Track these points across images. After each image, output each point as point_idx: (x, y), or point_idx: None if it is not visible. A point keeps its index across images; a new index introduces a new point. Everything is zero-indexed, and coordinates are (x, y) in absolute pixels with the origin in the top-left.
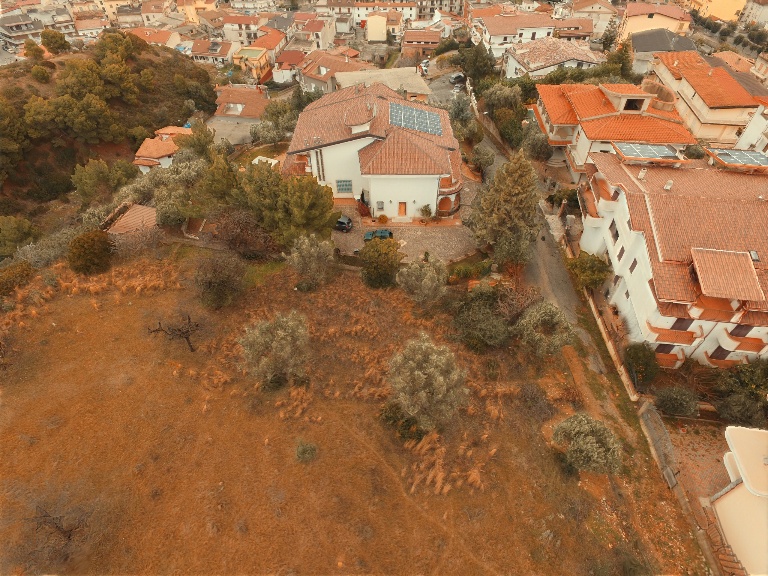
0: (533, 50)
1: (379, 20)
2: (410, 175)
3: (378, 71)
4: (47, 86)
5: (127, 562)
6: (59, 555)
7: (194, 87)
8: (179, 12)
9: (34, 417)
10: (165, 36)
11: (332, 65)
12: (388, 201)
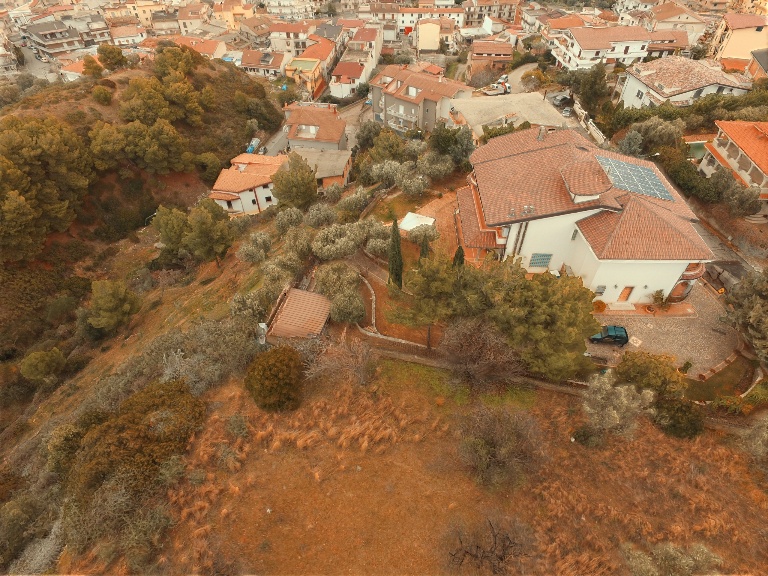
0: (660, 71)
1: (432, 28)
2: (663, 260)
3: (502, 98)
4: (109, 108)
5: None
6: None
7: (254, 104)
8: (221, 19)
9: None
10: (212, 46)
11: (424, 85)
12: (612, 286)
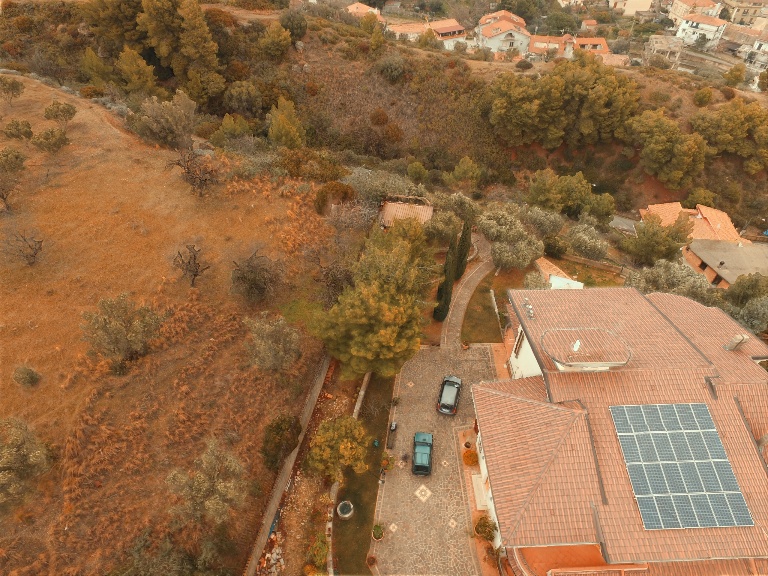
0: None
1: None
2: (485, 463)
3: None
4: (695, 108)
5: (7, 291)
6: (6, 253)
7: None
8: None
9: (158, 222)
10: None
11: None
12: None
